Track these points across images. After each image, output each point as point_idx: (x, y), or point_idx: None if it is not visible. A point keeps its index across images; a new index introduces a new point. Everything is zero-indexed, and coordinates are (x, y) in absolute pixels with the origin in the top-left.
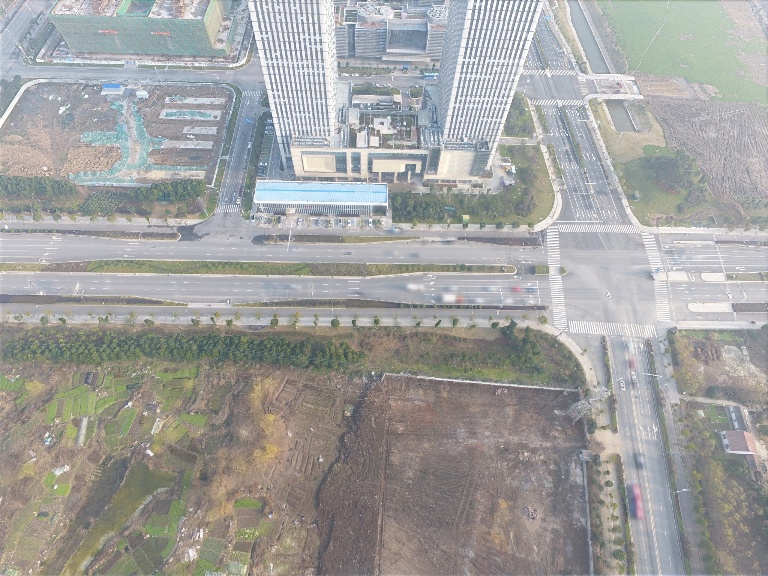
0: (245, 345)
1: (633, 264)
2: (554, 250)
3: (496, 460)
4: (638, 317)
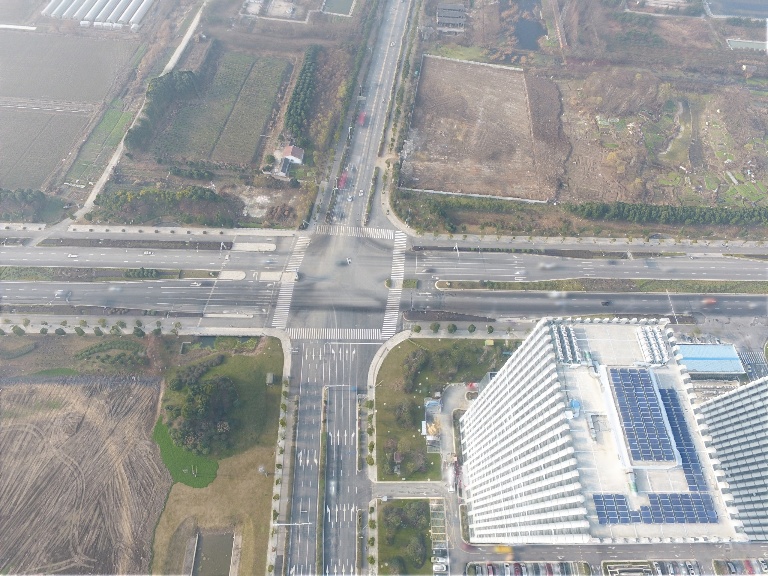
0: (662, 209)
1: (312, 290)
2: (392, 307)
3: (463, 156)
4: (328, 241)
